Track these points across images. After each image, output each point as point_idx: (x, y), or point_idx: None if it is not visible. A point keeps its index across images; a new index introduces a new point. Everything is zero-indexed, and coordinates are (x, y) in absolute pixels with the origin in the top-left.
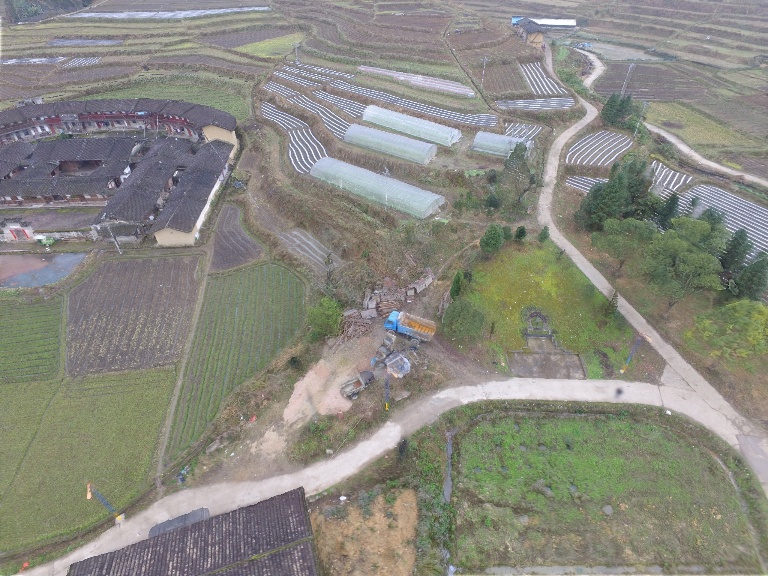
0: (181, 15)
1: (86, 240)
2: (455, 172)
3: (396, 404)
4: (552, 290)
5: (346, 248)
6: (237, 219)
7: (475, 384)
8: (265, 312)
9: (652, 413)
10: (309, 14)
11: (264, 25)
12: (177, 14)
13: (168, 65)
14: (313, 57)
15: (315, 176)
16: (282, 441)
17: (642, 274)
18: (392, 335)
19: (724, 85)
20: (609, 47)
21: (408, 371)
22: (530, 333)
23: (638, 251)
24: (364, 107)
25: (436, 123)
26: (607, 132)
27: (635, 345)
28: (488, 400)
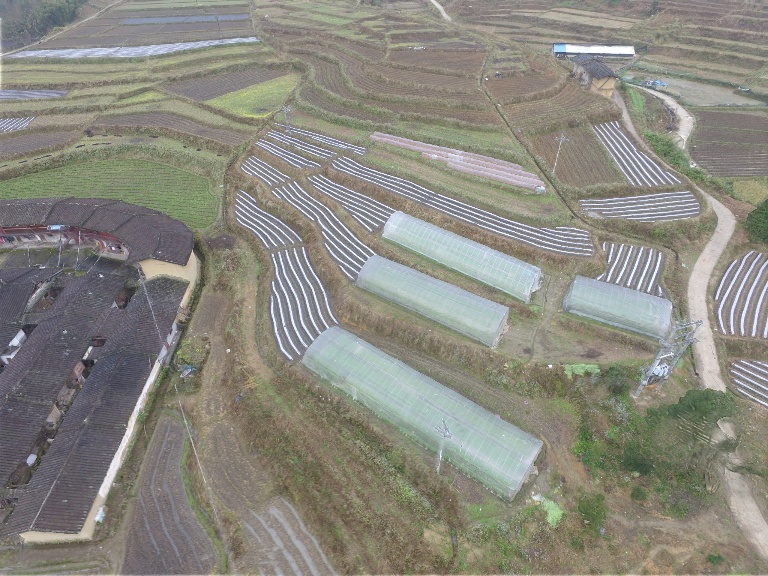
0: (147, 52)
1: None
2: (549, 371)
3: None
4: None
5: None
6: (178, 458)
7: None
8: None
9: None
10: (305, 47)
11: (249, 63)
12: (142, 50)
13: (118, 129)
14: (309, 116)
15: (311, 368)
16: None
17: None
18: None
19: None
20: (684, 84)
21: None
22: None
23: None
24: (383, 208)
25: (500, 254)
26: (758, 254)
27: None
28: None
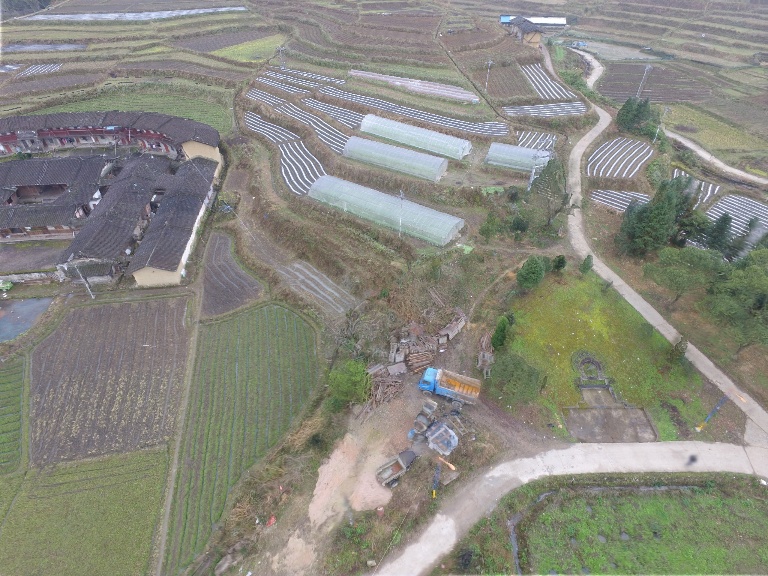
0: (150, 16)
1: (51, 282)
2: (472, 190)
3: (444, 489)
4: (603, 330)
5: (359, 284)
6: (228, 250)
7: (533, 455)
8: (271, 368)
9: (743, 482)
10: (289, 14)
11: (241, 26)
12: (145, 15)
13: (138, 72)
14: (298, 61)
15: (314, 197)
16: (311, 552)
17: (716, 315)
18: (433, 402)
19: (728, 85)
20: (603, 46)
21: (455, 446)
22: (584, 383)
23: (706, 286)
24: (360, 116)
25: (443, 134)
26: (624, 139)
27: (707, 395)
28: (552, 476)
